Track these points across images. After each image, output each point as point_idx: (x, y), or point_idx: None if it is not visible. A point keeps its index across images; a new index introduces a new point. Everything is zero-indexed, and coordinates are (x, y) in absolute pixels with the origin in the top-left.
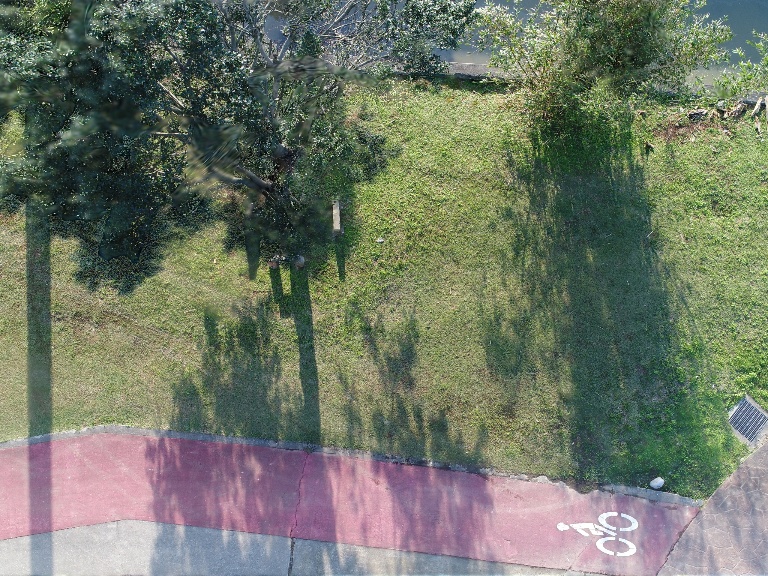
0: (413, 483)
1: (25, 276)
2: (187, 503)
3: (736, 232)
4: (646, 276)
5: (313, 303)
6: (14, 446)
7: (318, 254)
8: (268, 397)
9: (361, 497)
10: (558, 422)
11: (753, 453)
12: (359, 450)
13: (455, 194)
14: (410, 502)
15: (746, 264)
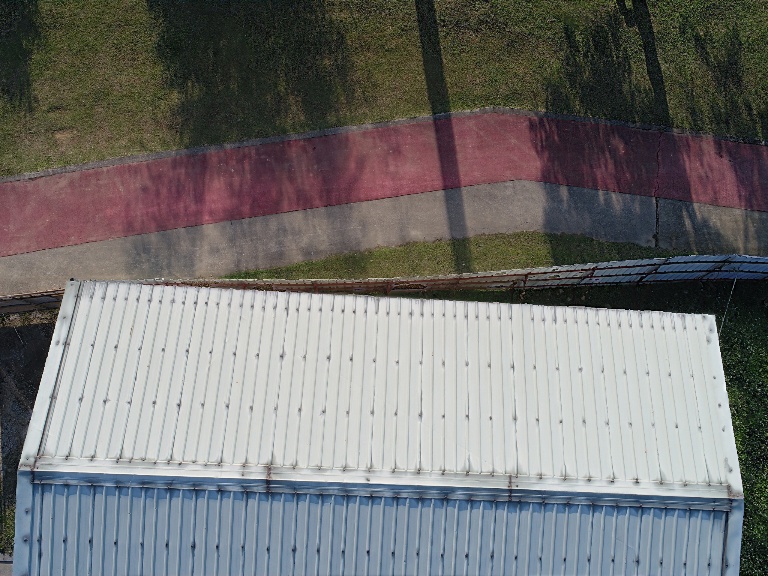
0: (750, 157)
1: None
2: (568, 168)
3: None
4: None
5: (652, 16)
6: (422, 121)
7: None
8: (624, 88)
9: (709, 167)
10: None
11: None
12: (703, 131)
13: None
14: (750, 172)
15: None
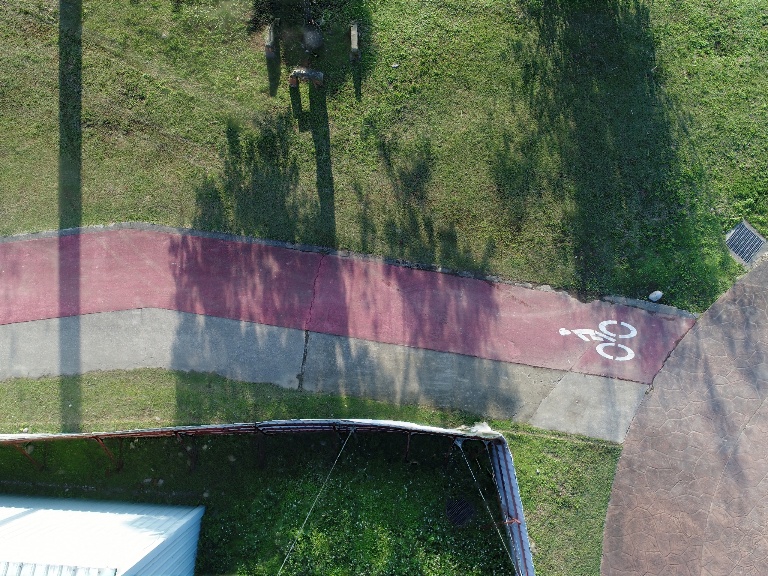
0: (422, 286)
1: (57, 85)
2: (208, 295)
3: (737, 69)
4: (649, 106)
5: (330, 120)
6: (45, 237)
7: (336, 76)
8: (286, 203)
9: (373, 297)
10: (562, 236)
11: (749, 272)
12: (372, 254)
13: (468, 26)
14: (419, 303)
15: (746, 99)
